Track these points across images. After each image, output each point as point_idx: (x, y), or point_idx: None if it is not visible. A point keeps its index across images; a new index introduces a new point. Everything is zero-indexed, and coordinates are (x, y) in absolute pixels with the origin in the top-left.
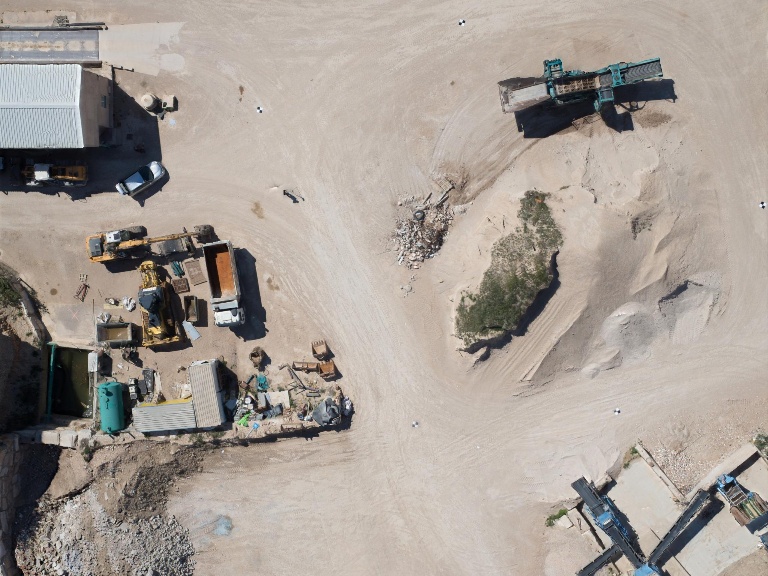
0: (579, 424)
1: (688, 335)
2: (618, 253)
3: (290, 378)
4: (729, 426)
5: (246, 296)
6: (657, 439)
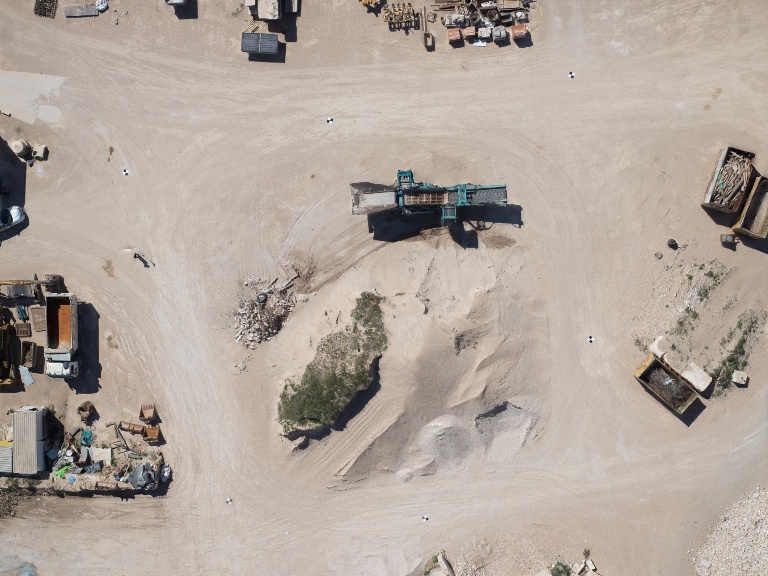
0: (387, 525)
1: (503, 454)
2: (438, 366)
3: (115, 437)
4: (531, 549)
5: (85, 350)
6: (460, 551)
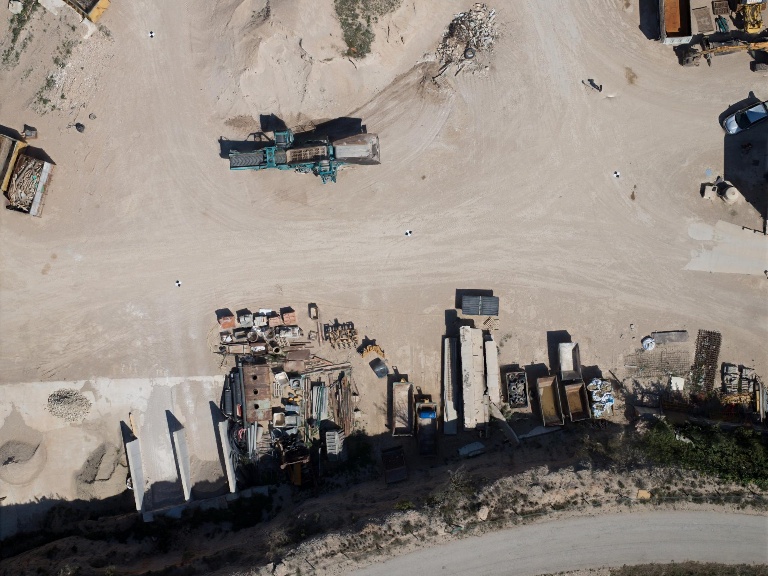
0: None
1: None
2: None
3: None
4: None
5: None
6: None
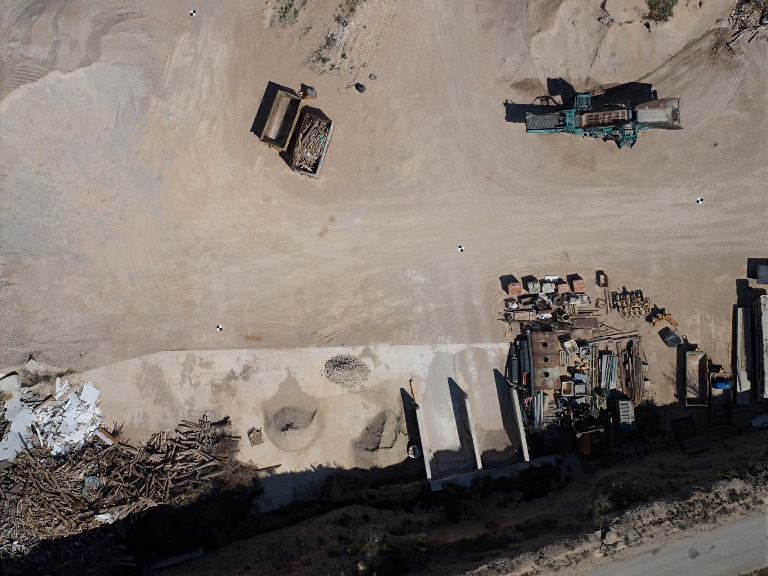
0: None
1: None
2: None
3: None
4: None
5: None
6: None
